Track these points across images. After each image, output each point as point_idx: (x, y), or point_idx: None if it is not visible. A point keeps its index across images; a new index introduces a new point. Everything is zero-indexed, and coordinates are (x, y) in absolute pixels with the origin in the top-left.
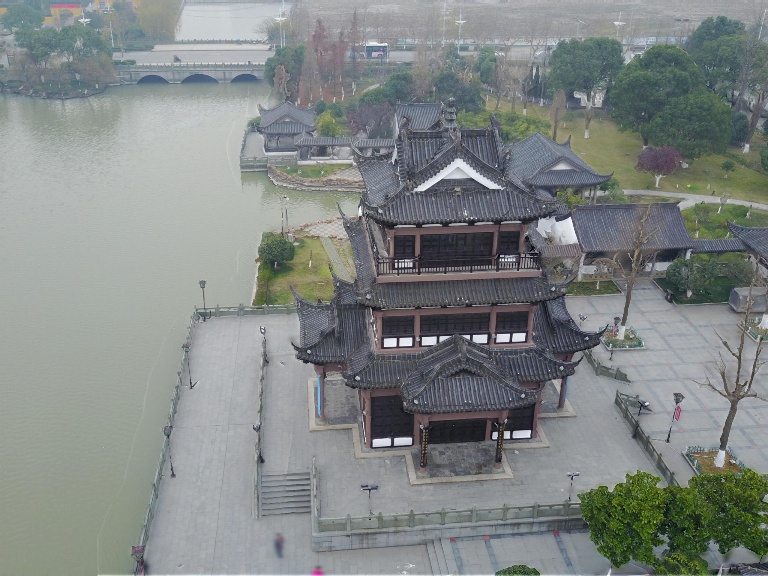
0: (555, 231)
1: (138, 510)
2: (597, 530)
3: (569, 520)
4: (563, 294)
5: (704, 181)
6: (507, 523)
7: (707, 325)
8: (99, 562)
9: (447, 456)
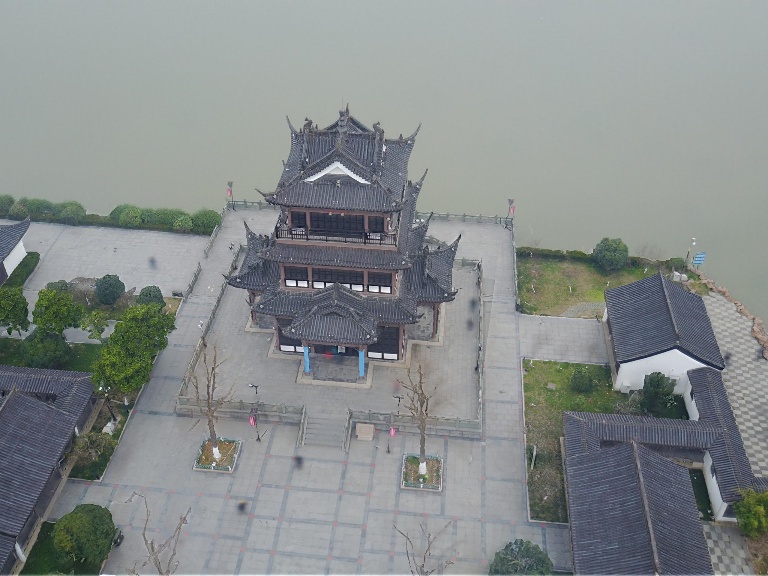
0: None
1: None
2: None
3: None
4: None
5: None
6: None
7: (442, 573)
8: None
9: None
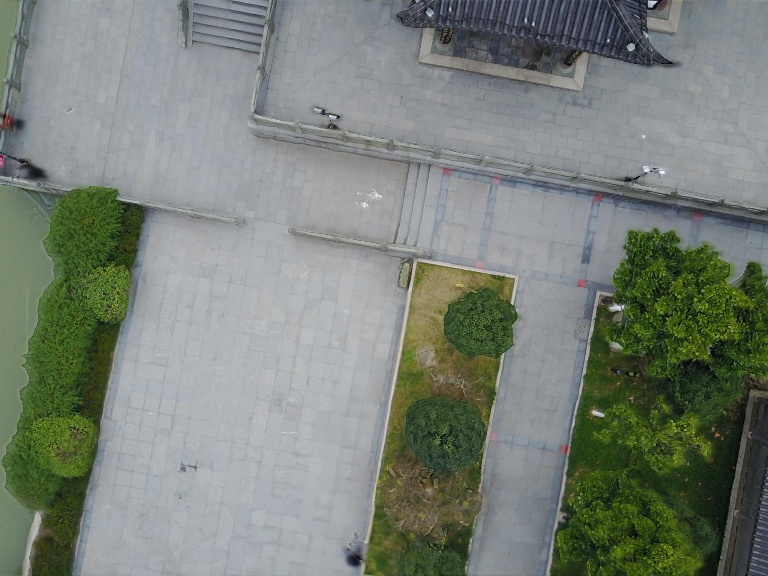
0: None
1: None
2: None
3: (622, 196)
4: None
5: None
6: (530, 178)
7: None
8: None
9: None
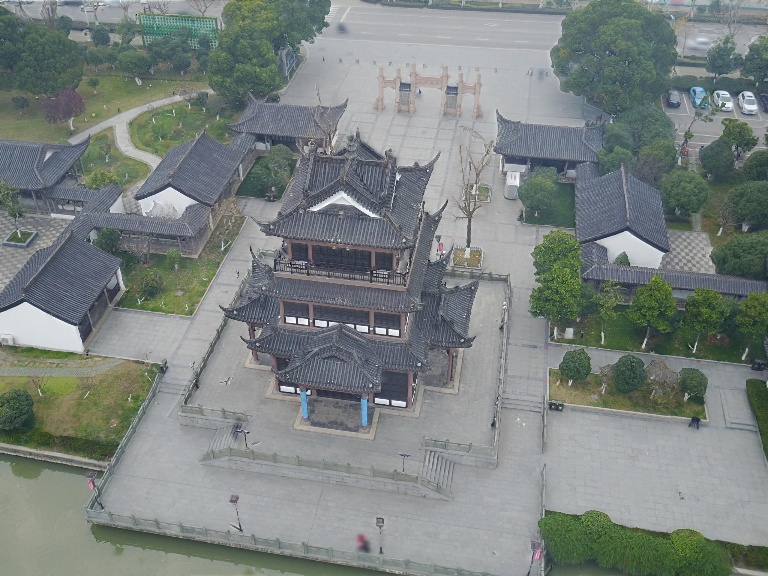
0: (162, 207)
1: None
2: (553, 314)
3: None
4: None
5: (88, 105)
6: None
7: None
8: None
9: (434, 367)
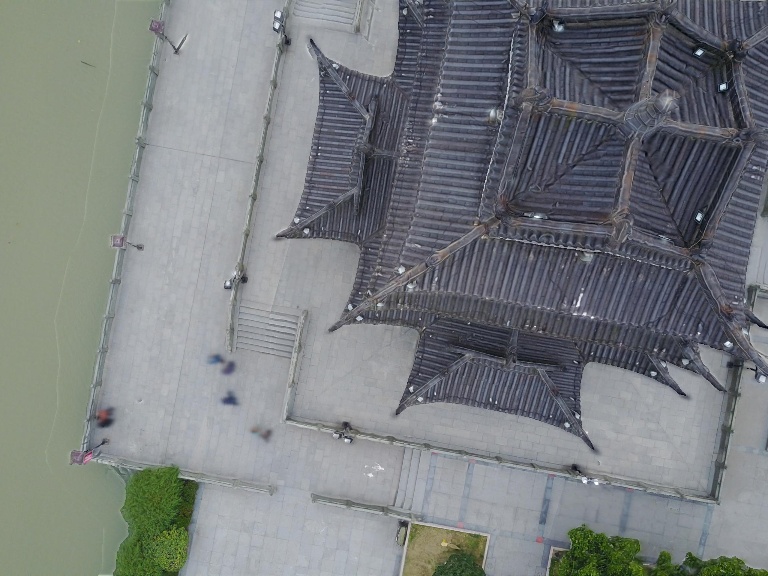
0: None
1: (105, 260)
2: None
3: None
4: None
5: None
6: None
7: None
8: (60, 350)
9: None
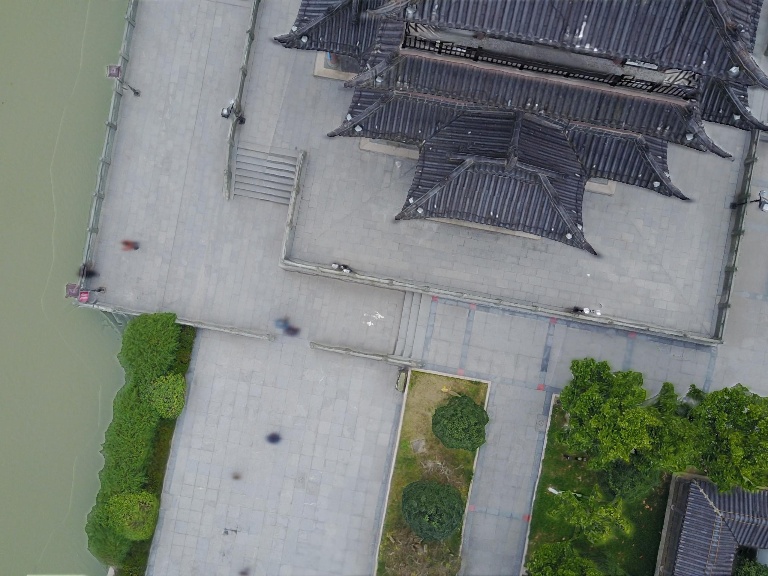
0: None
1: (101, 112)
2: None
3: None
4: (700, 149)
5: None
6: (500, 307)
7: None
8: (55, 201)
9: None
